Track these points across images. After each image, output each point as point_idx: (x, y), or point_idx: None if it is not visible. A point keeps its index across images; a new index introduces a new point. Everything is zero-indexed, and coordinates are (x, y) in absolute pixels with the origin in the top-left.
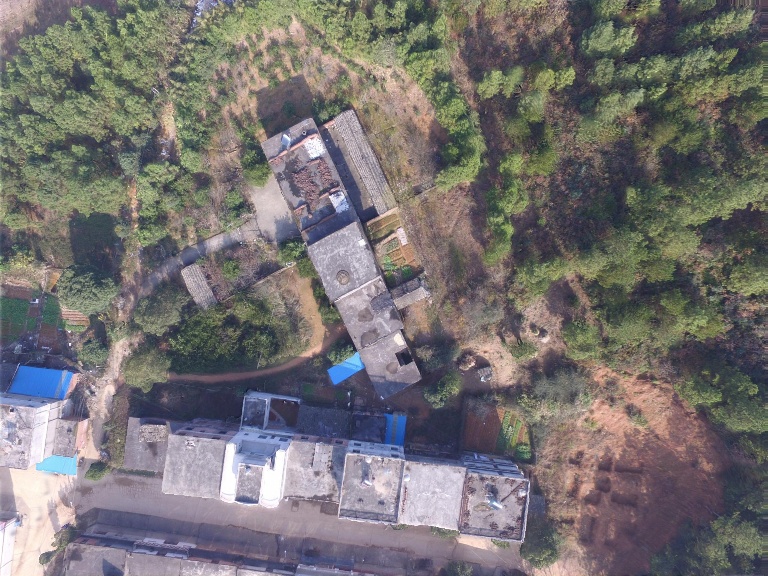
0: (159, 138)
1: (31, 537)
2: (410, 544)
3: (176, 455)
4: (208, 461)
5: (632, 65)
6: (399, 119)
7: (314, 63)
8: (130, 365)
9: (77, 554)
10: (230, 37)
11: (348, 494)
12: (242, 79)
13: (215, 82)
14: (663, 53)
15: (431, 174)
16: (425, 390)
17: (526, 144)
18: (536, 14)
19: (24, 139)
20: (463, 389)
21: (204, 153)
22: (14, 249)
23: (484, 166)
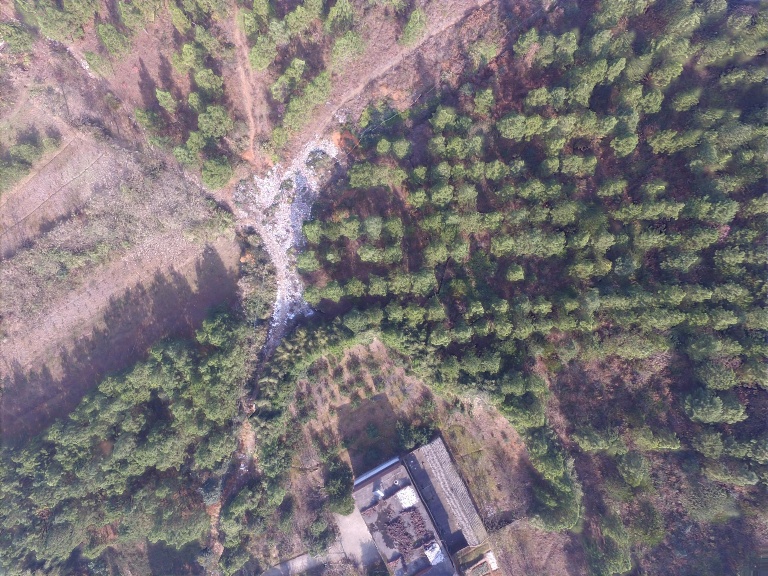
0: (237, 453)
1: None
2: None
3: None
4: None
5: (742, 446)
6: (486, 442)
7: (396, 382)
8: None
9: None
10: (311, 362)
11: None
12: (322, 395)
13: (294, 397)
14: None
15: (521, 501)
16: None
17: (626, 497)
18: (632, 360)
19: (105, 483)
20: None
21: (286, 478)
22: (91, 567)
23: (583, 518)
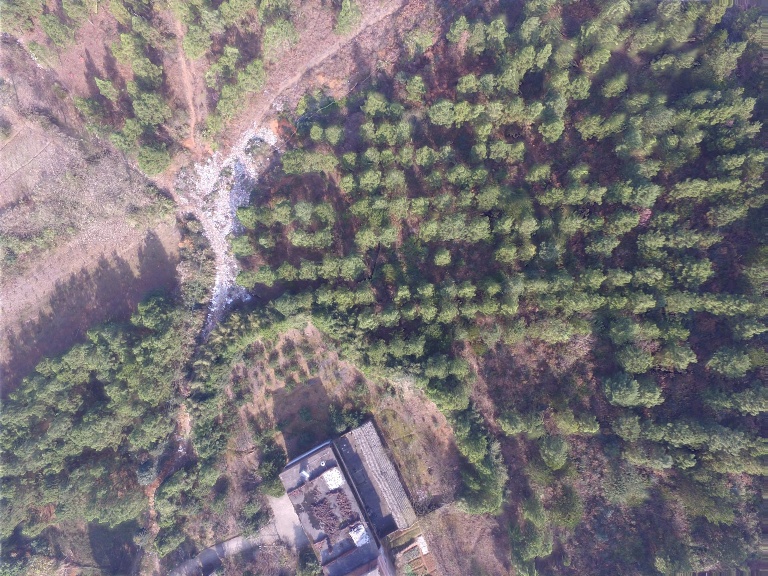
0: (176, 436)
1: None
2: None
3: None
4: None
5: (658, 430)
6: (417, 427)
7: (330, 366)
8: None
9: None
10: (245, 345)
11: None
12: (258, 379)
13: (231, 381)
14: (691, 424)
15: (451, 485)
16: None
17: (549, 481)
18: (557, 344)
19: (42, 461)
20: None
21: (221, 459)
22: (33, 546)
23: (506, 501)
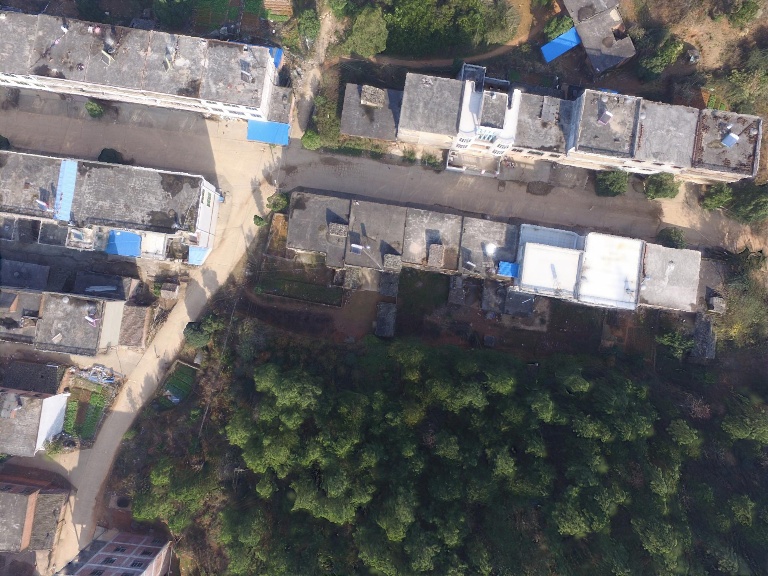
0: None
1: (234, 214)
2: (614, 223)
3: (414, 92)
4: (445, 99)
5: None
6: None
7: None
8: (363, 13)
9: (301, 203)
10: None
11: (584, 131)
12: None
13: None
14: None
15: None
16: (643, 58)
17: None
18: None
19: None
20: (669, 74)
21: None
22: None
23: None
